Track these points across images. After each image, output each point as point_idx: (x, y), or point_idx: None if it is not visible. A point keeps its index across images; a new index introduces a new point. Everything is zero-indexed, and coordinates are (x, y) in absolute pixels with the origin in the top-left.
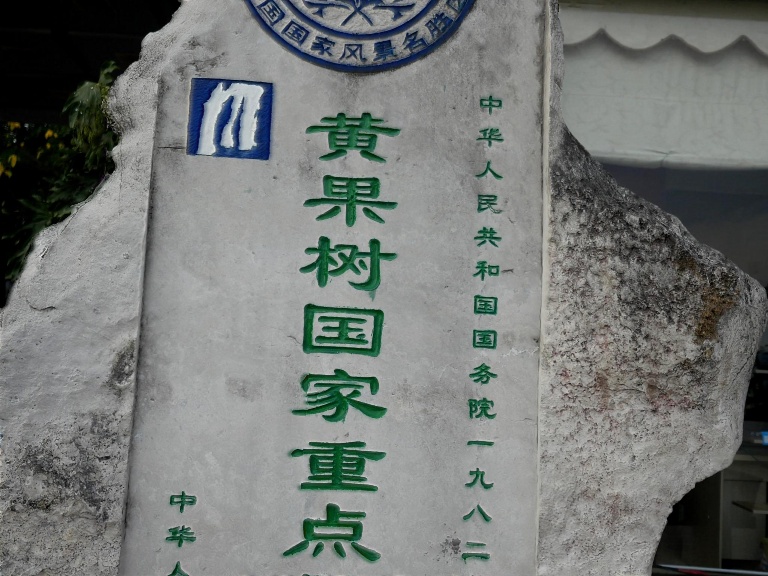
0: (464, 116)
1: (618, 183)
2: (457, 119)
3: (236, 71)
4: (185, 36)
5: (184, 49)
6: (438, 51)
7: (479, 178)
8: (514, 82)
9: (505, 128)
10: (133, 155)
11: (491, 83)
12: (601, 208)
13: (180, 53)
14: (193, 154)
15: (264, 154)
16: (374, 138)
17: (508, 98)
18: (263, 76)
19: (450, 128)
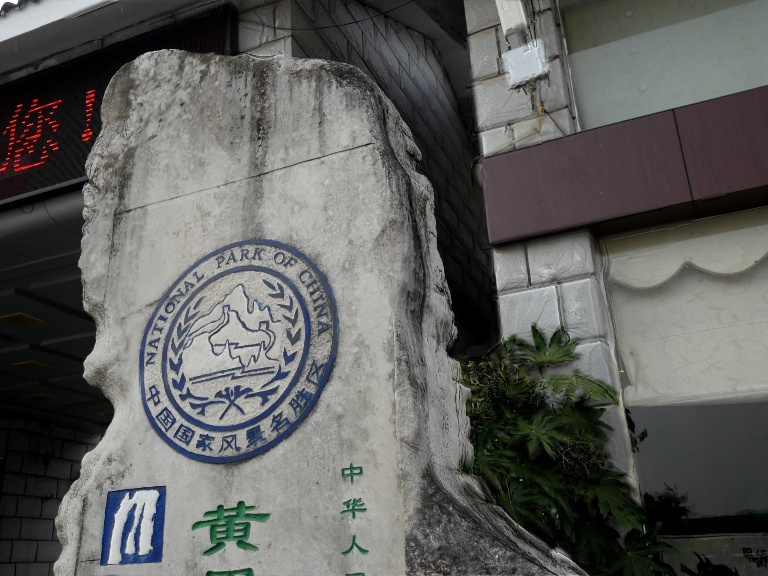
0: (327, 489)
1: (491, 541)
2: (321, 494)
3: (139, 480)
4: (106, 454)
5: (104, 466)
6: (301, 427)
7: (346, 555)
8: (372, 444)
9: (367, 495)
10: (65, 571)
11: (351, 450)
12: None
13: (101, 470)
14: (105, 565)
15: (159, 556)
16: (249, 526)
17: (368, 463)
18: (159, 480)
19: (315, 504)
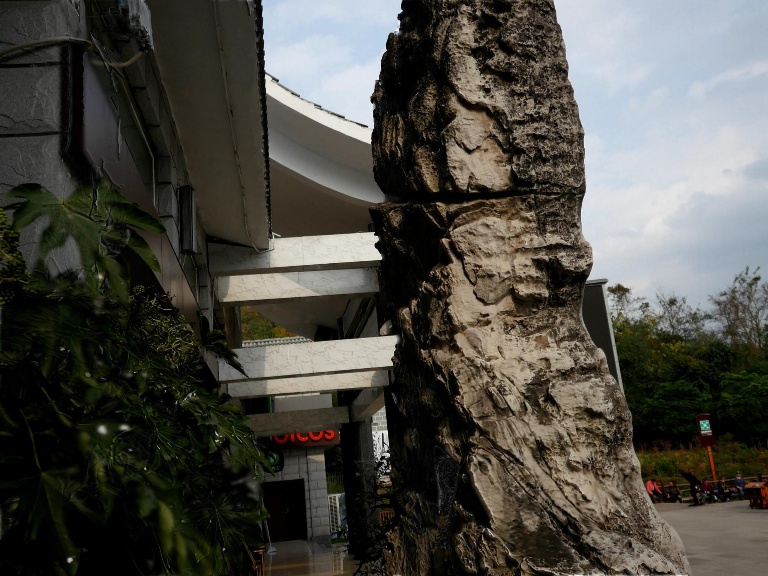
0: None
1: None
2: None
3: None
4: None
5: None
6: None
7: None
8: None
9: None
10: None
11: None
12: None
13: None
14: None
15: None
16: None
17: None
18: None
19: None
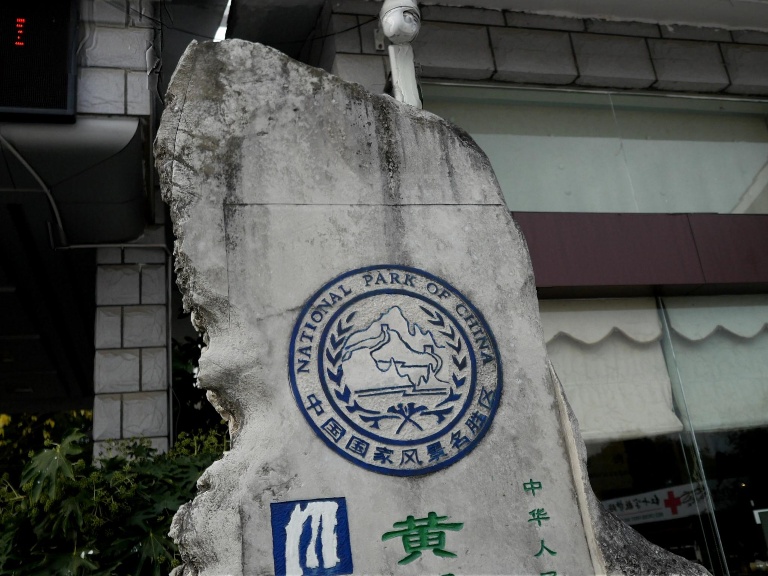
0: (513, 501)
1: (648, 541)
2: (508, 505)
3: (311, 491)
4: (258, 463)
5: (259, 476)
6: (480, 445)
7: (538, 557)
8: (547, 463)
9: (548, 506)
10: None
11: (529, 467)
12: (647, 571)
13: (256, 480)
14: None
15: (348, 568)
16: (442, 535)
17: (545, 479)
18: (336, 492)
19: (504, 514)
